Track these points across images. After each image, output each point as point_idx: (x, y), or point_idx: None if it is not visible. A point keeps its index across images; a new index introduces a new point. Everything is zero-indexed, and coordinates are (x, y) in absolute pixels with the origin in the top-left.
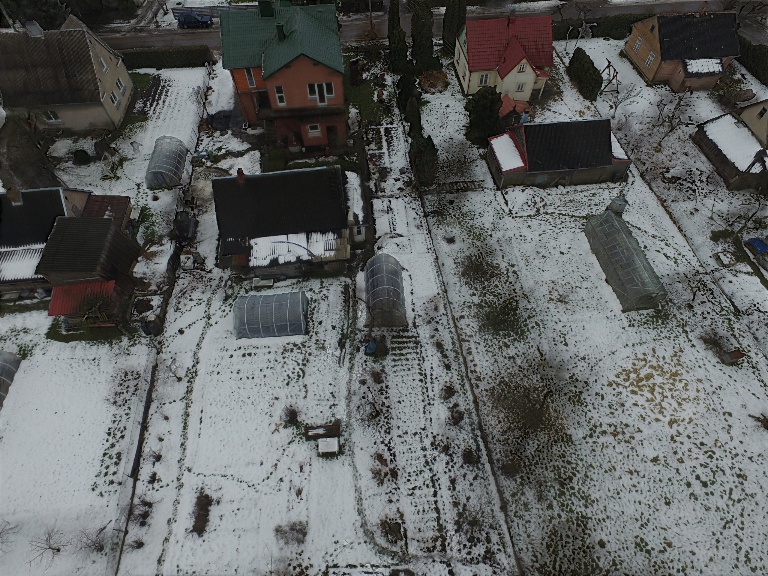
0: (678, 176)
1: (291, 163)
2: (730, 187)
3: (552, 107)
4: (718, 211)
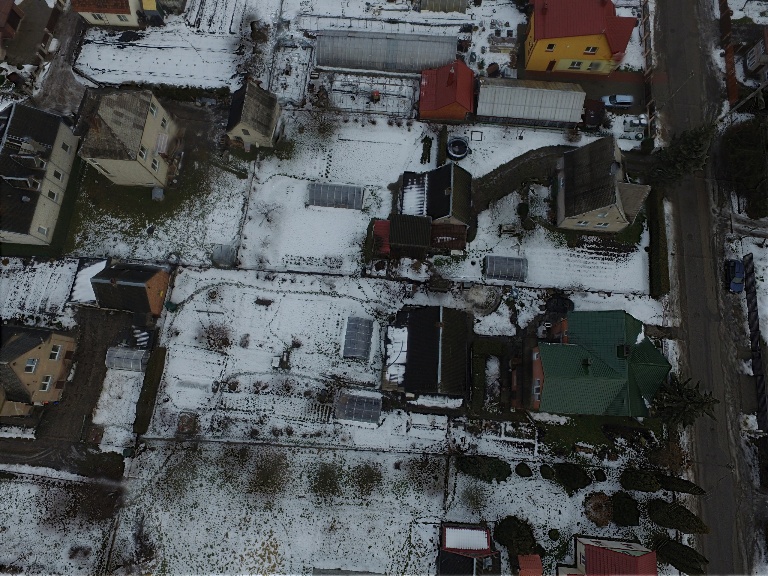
0: None
1: (496, 359)
2: None
3: None
4: None
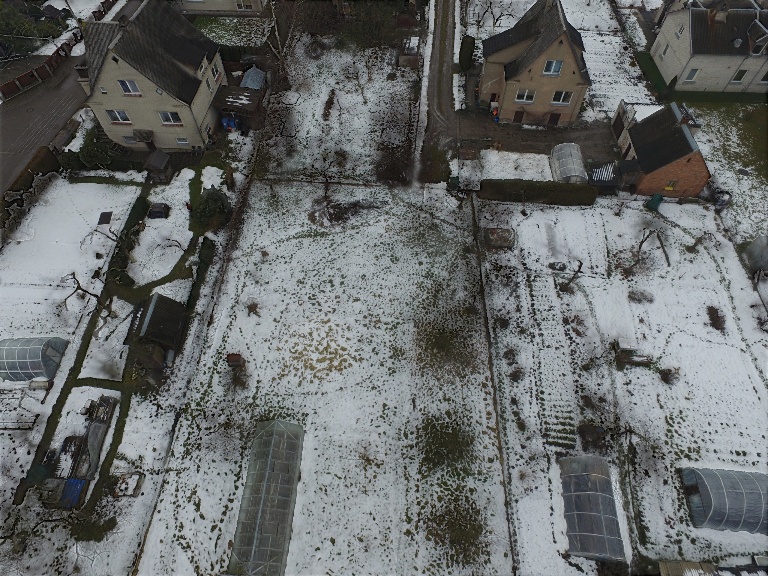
0: None
1: None
2: None
3: None
4: None
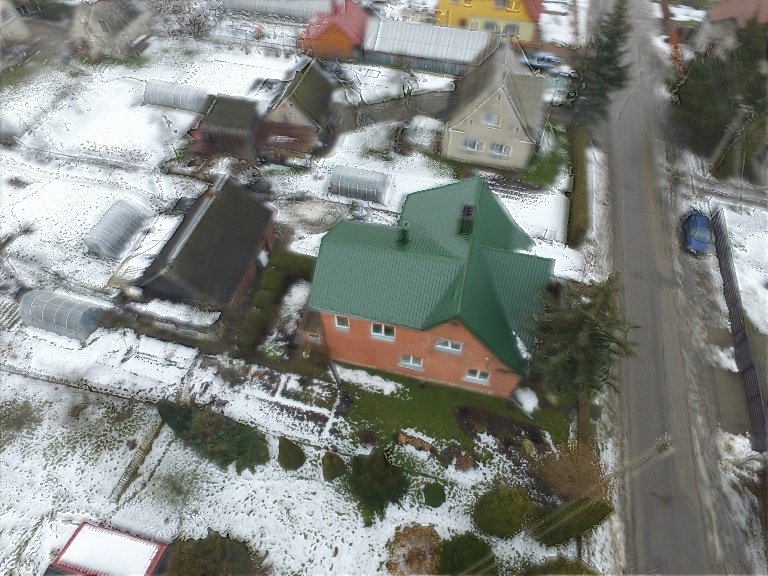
0: None
1: (309, 285)
2: None
3: None
4: None
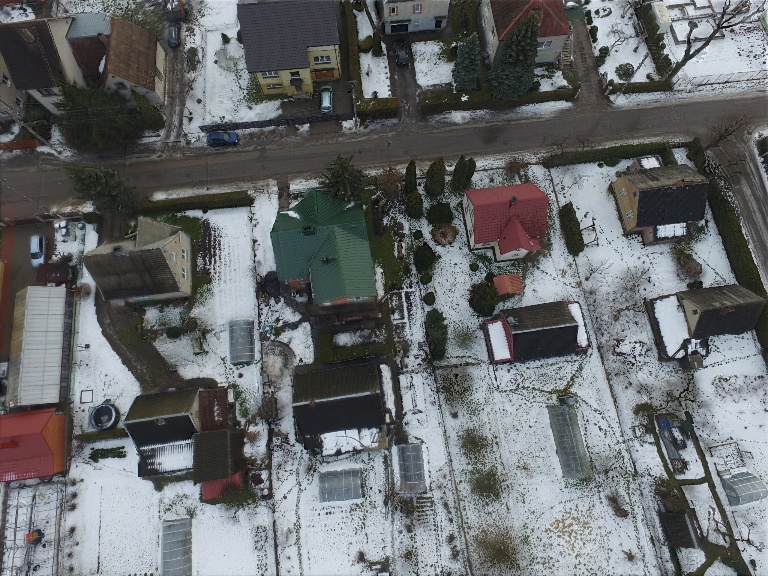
0: (624, 353)
1: (335, 337)
2: (660, 360)
3: (541, 265)
4: (645, 385)
